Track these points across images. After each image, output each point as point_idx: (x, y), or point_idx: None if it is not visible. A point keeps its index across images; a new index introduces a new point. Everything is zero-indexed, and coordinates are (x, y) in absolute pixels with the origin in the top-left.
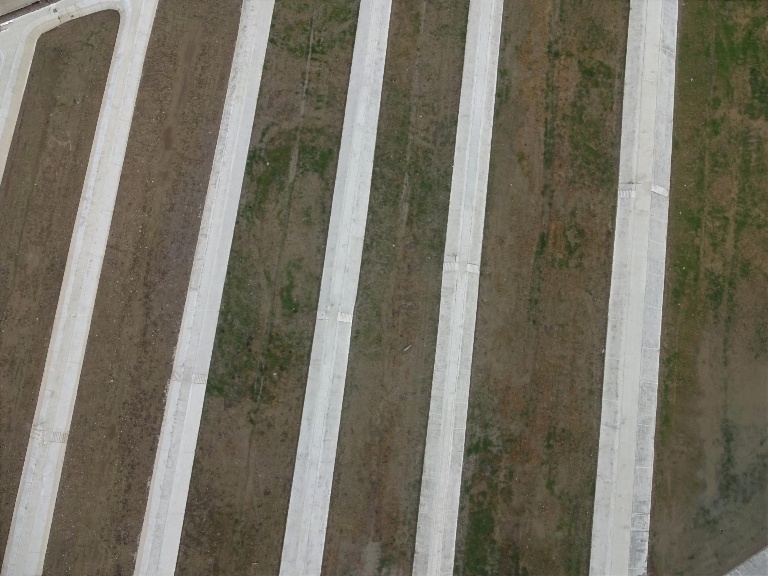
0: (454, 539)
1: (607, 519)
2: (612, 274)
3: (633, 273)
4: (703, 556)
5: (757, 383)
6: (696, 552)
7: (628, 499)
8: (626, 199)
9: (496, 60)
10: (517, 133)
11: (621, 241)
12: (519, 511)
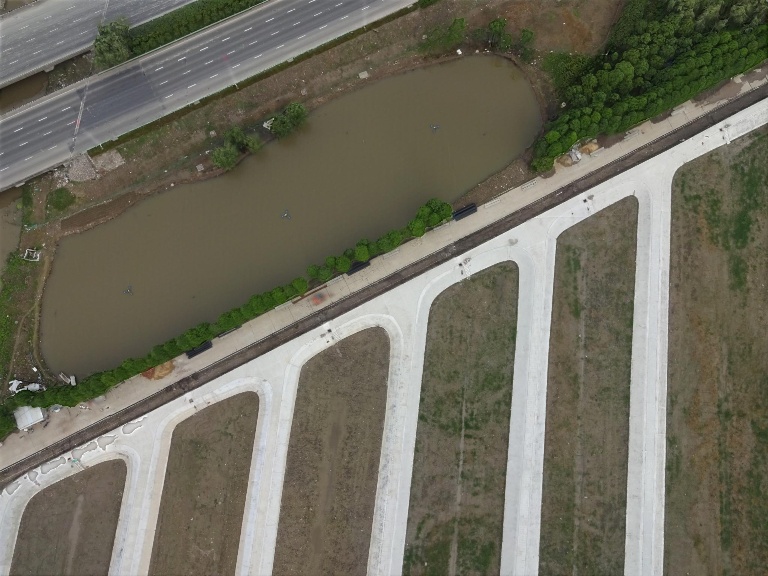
0: None
1: None
2: None
3: None
4: None
5: None
6: None
7: None
8: None
9: (664, 427)
10: (691, 512)
11: None
12: None
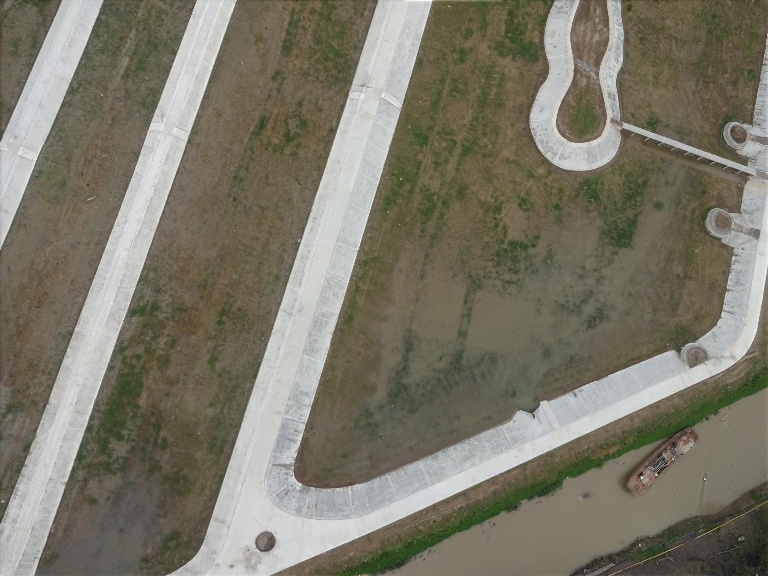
0: (94, 397)
1: (261, 402)
2: (326, 169)
3: (344, 170)
4: (357, 457)
5: (449, 301)
6: (350, 451)
7: (287, 386)
8: (355, 100)
9: None
10: (260, 15)
11: (341, 139)
12: (173, 381)
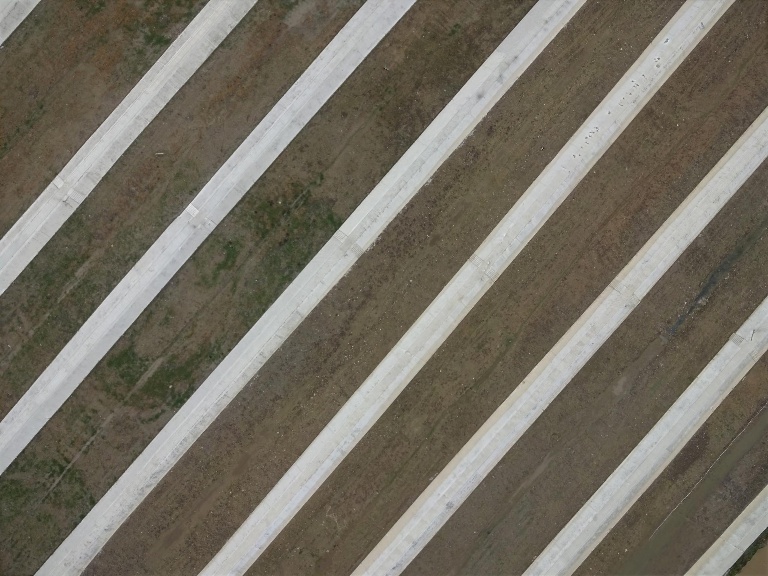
0: None
1: None
2: None
3: None
4: None
5: None
6: None
7: None
8: None
9: None
10: None
11: None
12: None
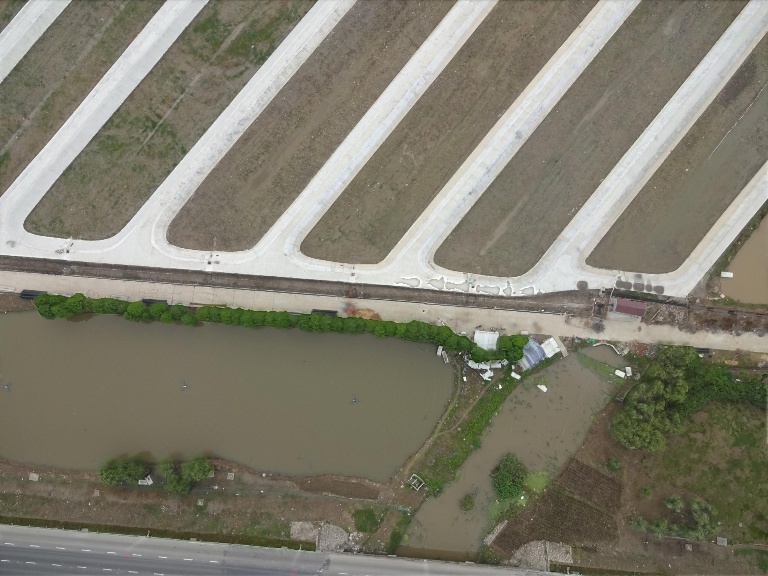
0: None
1: None
2: None
3: None
4: None
5: None
6: None
7: None
8: None
9: (5, 30)
10: None
11: None
12: None
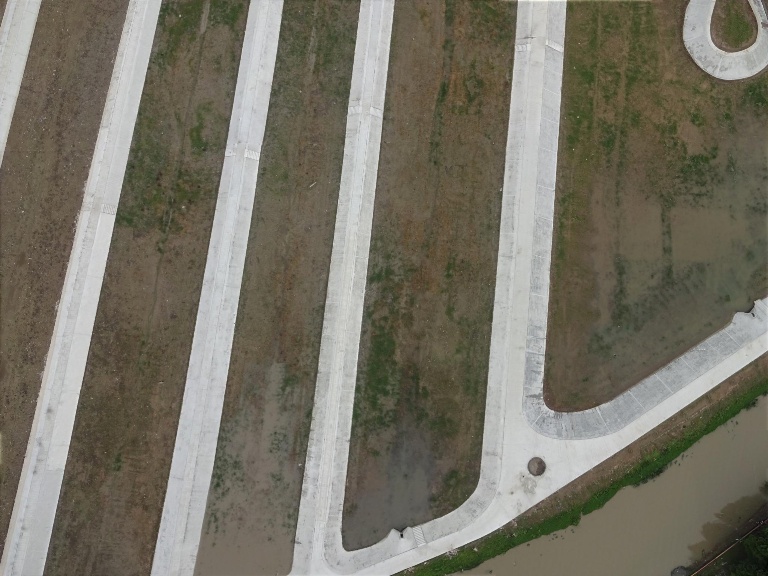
0: (356, 360)
1: (503, 341)
2: (509, 120)
3: (528, 118)
4: (597, 379)
5: (648, 222)
6: (590, 375)
7: (523, 322)
8: (522, 52)
9: None
10: None
11: (517, 90)
12: (420, 335)
